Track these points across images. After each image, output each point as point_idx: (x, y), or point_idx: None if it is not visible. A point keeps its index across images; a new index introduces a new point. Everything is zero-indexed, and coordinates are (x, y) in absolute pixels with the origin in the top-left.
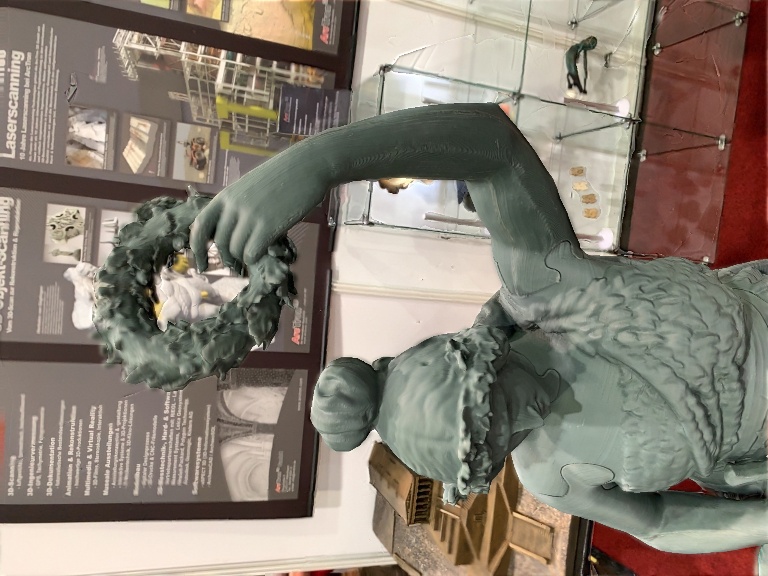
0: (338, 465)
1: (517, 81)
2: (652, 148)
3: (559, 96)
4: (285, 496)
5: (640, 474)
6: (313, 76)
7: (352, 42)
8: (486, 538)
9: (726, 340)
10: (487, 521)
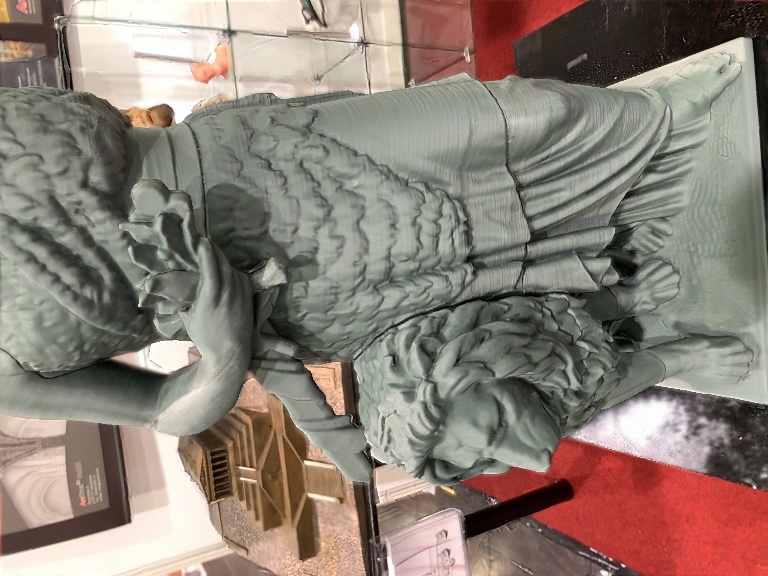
0: (156, 462)
1: (224, 18)
2: (419, 76)
3: (281, 29)
4: (94, 508)
5: (18, 343)
6: (18, 51)
7: (57, 8)
8: (285, 494)
9: (55, 160)
10: (283, 477)
